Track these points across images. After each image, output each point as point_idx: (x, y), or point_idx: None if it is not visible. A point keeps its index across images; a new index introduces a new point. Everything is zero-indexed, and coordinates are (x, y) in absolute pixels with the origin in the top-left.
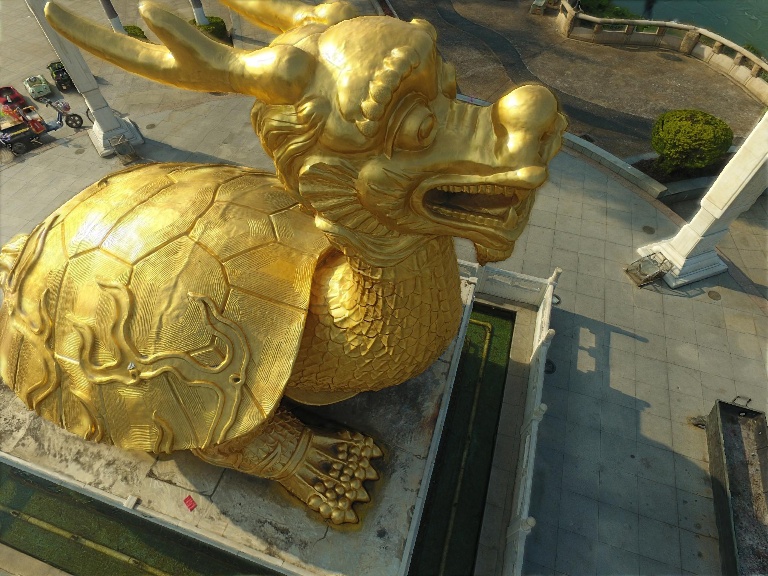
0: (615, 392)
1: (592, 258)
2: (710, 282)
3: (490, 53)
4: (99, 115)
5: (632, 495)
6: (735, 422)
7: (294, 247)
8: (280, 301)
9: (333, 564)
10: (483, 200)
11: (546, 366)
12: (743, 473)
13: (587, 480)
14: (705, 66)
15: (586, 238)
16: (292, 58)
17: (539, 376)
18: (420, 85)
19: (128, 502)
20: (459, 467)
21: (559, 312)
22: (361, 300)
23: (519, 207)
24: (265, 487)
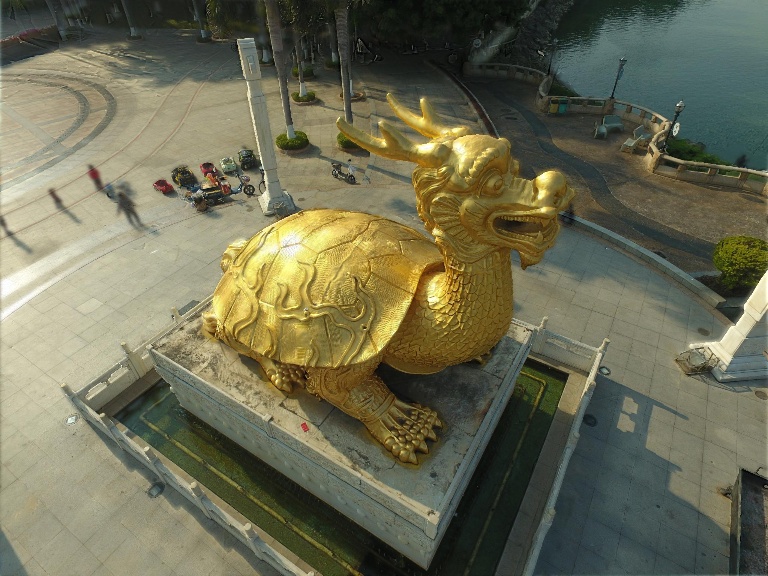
0: (650, 453)
1: (645, 345)
2: (759, 383)
3: (579, 178)
4: (271, 186)
5: (653, 536)
6: (758, 492)
7: (412, 259)
8: (399, 287)
9: (396, 485)
10: (527, 229)
11: (589, 420)
12: (759, 534)
13: (612, 515)
14: None
15: (642, 329)
16: (441, 148)
17: (578, 417)
18: (498, 166)
19: (266, 417)
20: (501, 483)
21: (608, 381)
22: (449, 290)
23: (546, 234)
24: (356, 429)
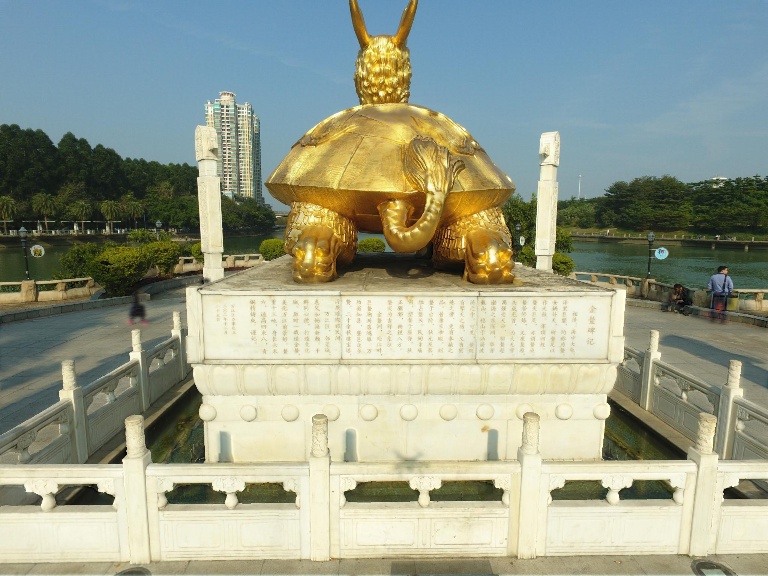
0: None
1: None
2: None
3: None
4: None
5: None
6: None
7: None
8: None
9: None
10: None
11: None
12: None
13: None
14: None
15: None
16: None
17: None
18: None
19: None
20: None
21: None
22: None
23: None
24: None
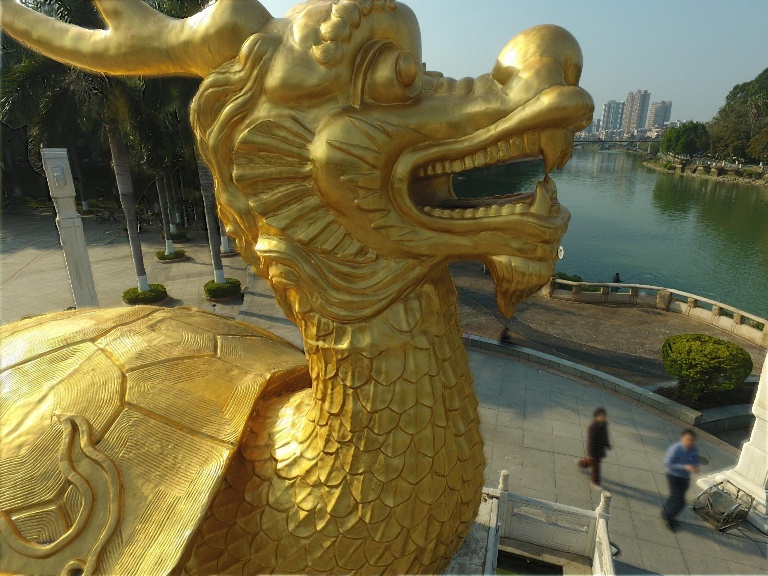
0: None
1: (643, 493)
2: None
3: (481, 308)
4: None
5: None
6: None
7: (238, 364)
8: (196, 430)
9: None
10: None
11: None
12: None
13: None
14: (686, 318)
15: (627, 468)
16: None
17: None
18: (398, 39)
19: None
20: None
21: (623, 567)
22: (321, 414)
23: None
24: None
